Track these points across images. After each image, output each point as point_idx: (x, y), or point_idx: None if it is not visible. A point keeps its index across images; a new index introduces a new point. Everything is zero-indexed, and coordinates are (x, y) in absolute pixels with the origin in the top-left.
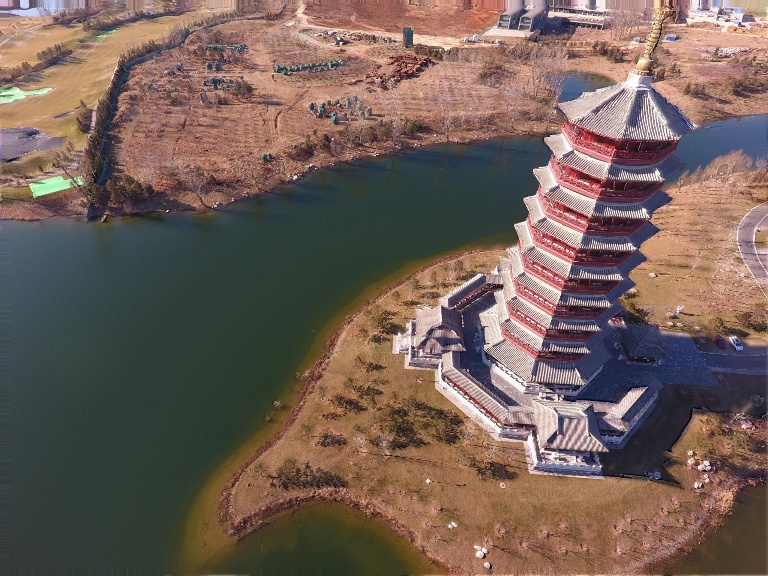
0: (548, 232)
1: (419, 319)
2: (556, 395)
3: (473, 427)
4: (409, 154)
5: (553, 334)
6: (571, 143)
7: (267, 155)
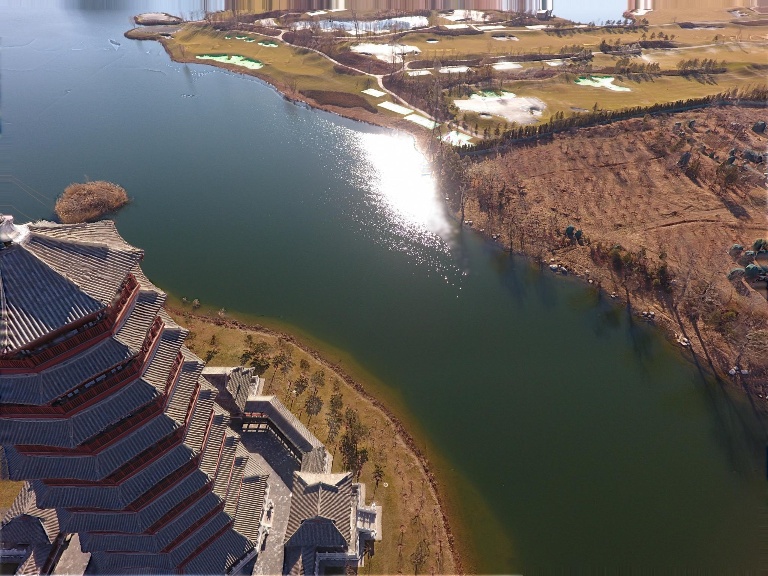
0: None
1: None
2: None
3: None
4: (722, 388)
5: None
6: None
7: (577, 230)
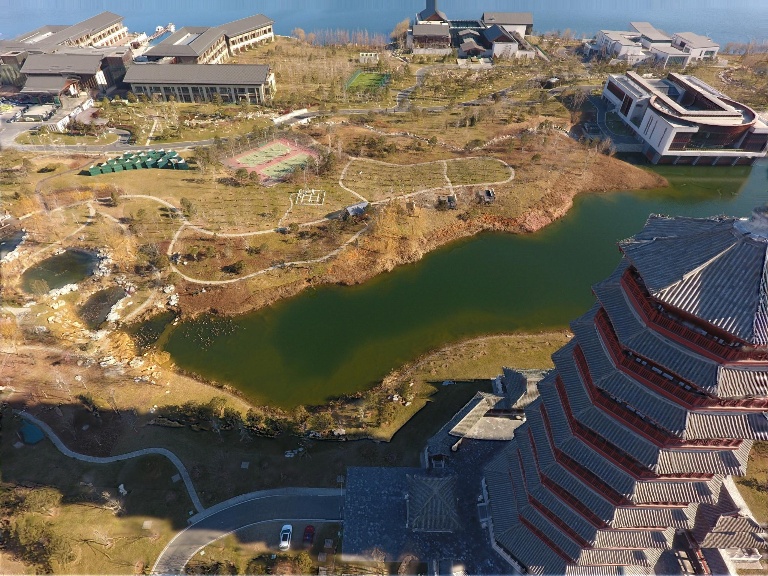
0: None
1: None
2: None
3: None
4: None
5: None
6: None
7: None
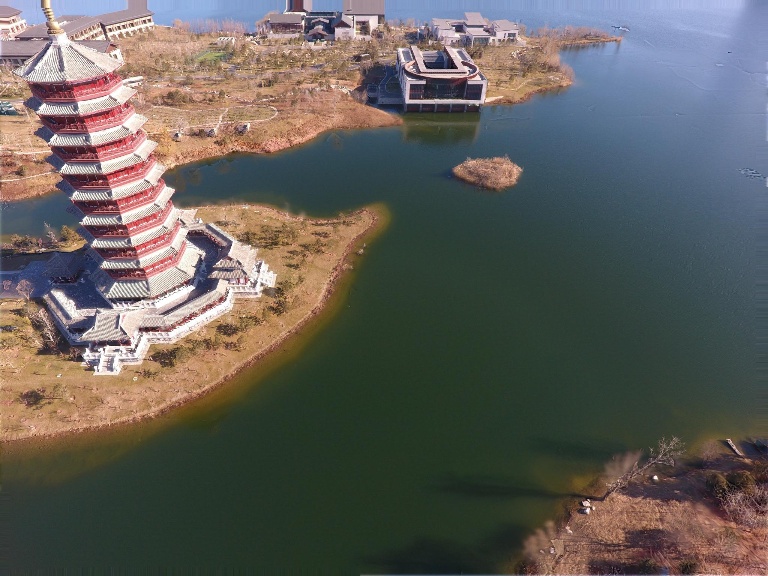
0: None
1: (249, 268)
2: None
3: None
4: None
5: None
6: None
7: None
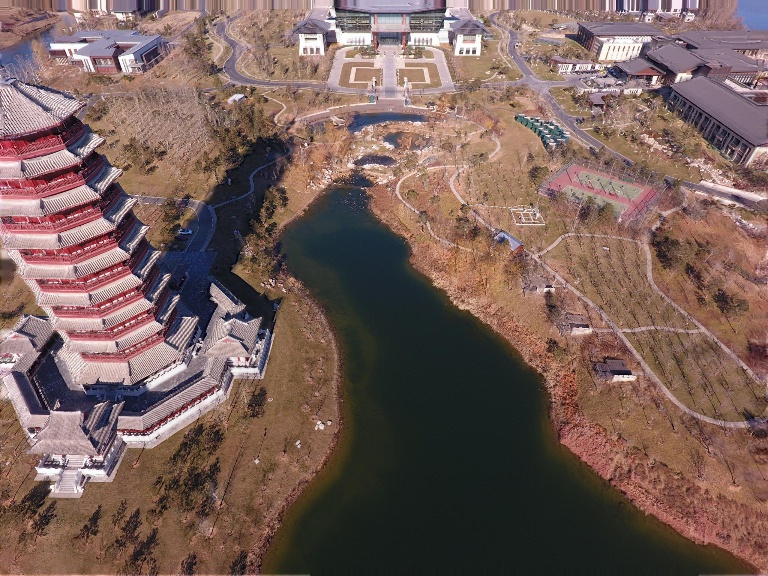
0: (78, 241)
1: (51, 449)
2: (197, 344)
3: (210, 416)
4: None
5: (155, 310)
6: (14, 156)
7: None
